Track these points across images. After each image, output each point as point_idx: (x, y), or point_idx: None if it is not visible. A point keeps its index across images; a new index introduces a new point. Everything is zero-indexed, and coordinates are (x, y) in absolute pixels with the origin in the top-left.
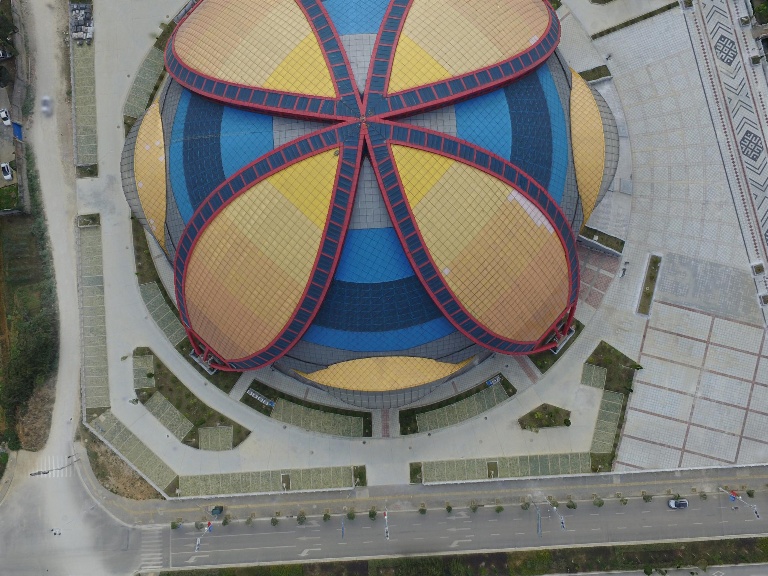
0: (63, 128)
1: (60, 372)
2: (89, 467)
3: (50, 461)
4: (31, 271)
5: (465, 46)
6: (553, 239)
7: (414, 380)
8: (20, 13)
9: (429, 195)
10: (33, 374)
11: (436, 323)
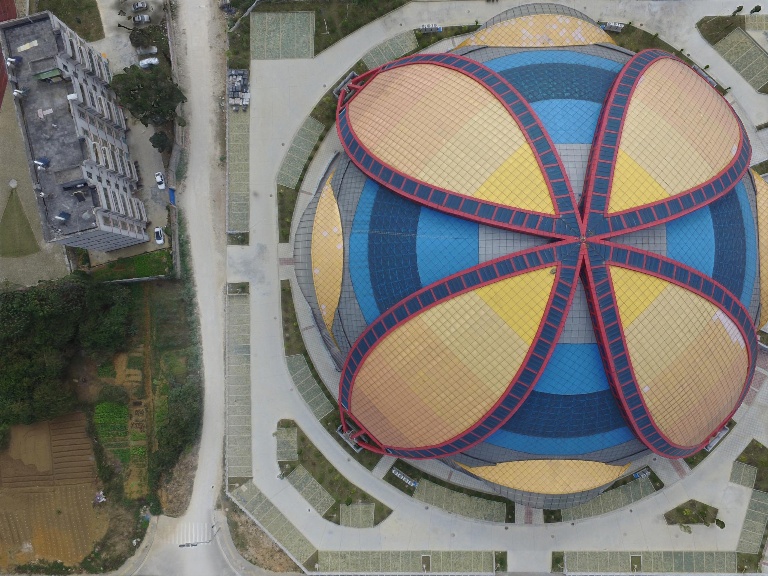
0: (216, 194)
1: (203, 439)
2: (229, 536)
3: (190, 528)
4: (179, 337)
5: (679, 162)
6: (742, 353)
7: (586, 484)
8: (177, 76)
9: (641, 316)
10: (182, 444)
11: (618, 432)
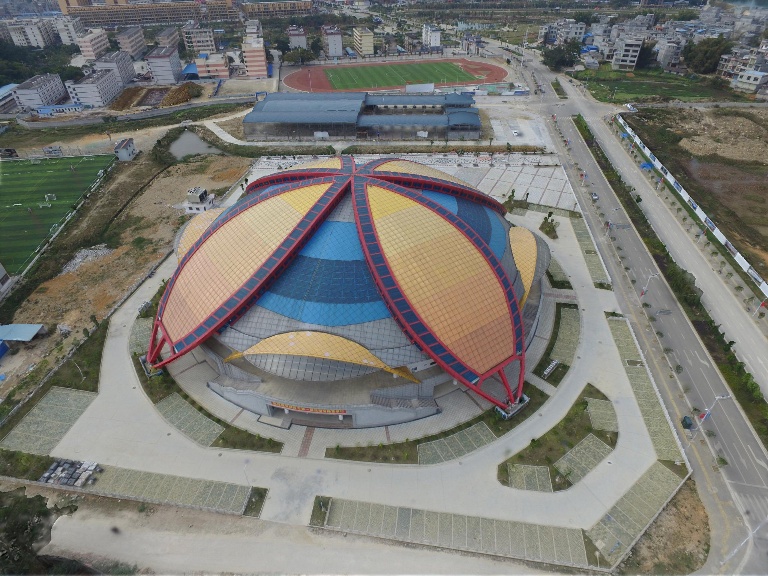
0: (183, 524)
1: None
2: None
3: None
4: None
5: None
6: None
7: None
8: None
9: None
10: None
11: (486, 209)
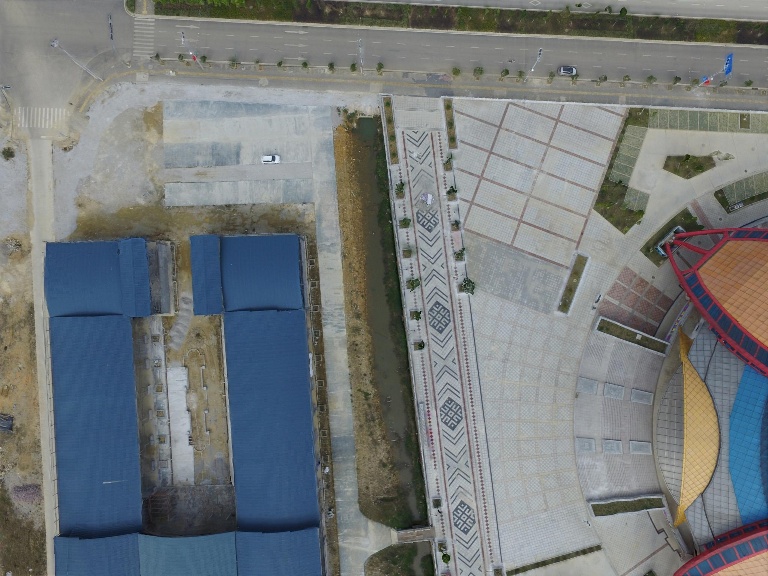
0: None
1: None
2: None
3: None
4: None
5: None
6: None
7: None
8: None
9: None
10: None
11: None
